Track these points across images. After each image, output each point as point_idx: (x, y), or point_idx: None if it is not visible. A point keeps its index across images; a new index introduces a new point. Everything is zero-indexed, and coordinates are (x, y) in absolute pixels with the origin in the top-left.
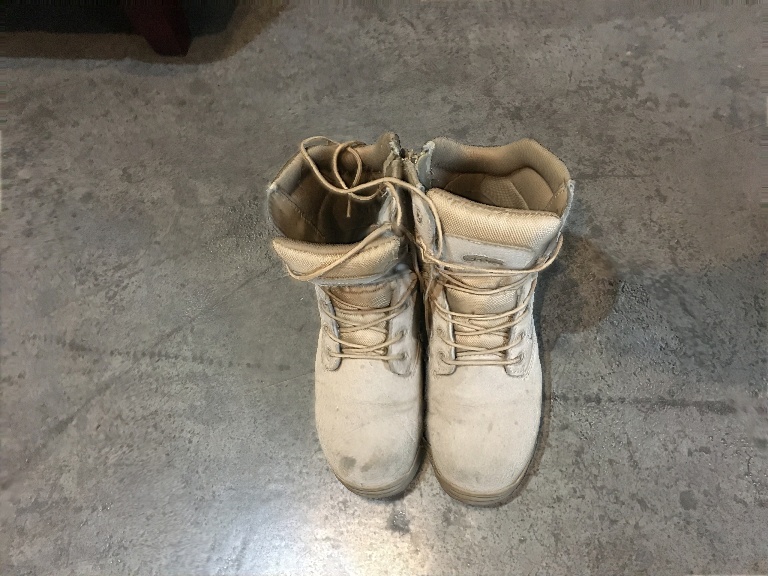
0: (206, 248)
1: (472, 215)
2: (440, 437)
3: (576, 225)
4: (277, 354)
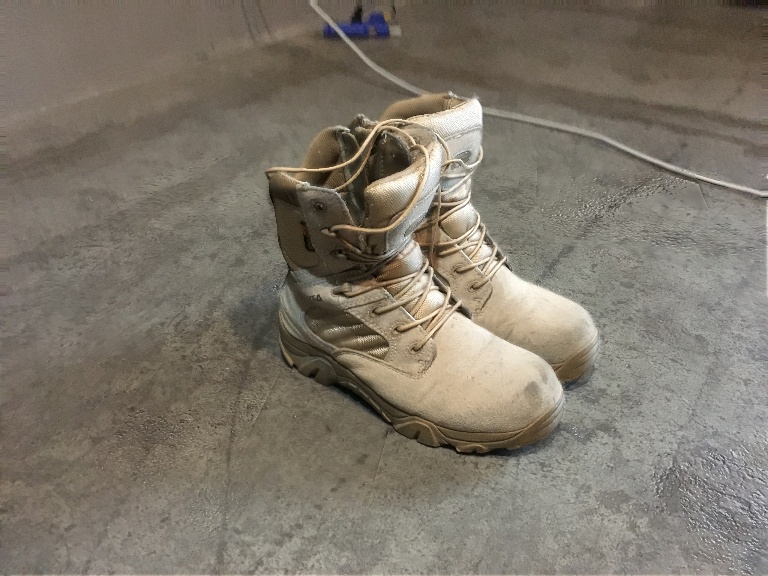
0: (141, 477)
1: (446, 115)
2: (537, 332)
3: None
4: (342, 459)
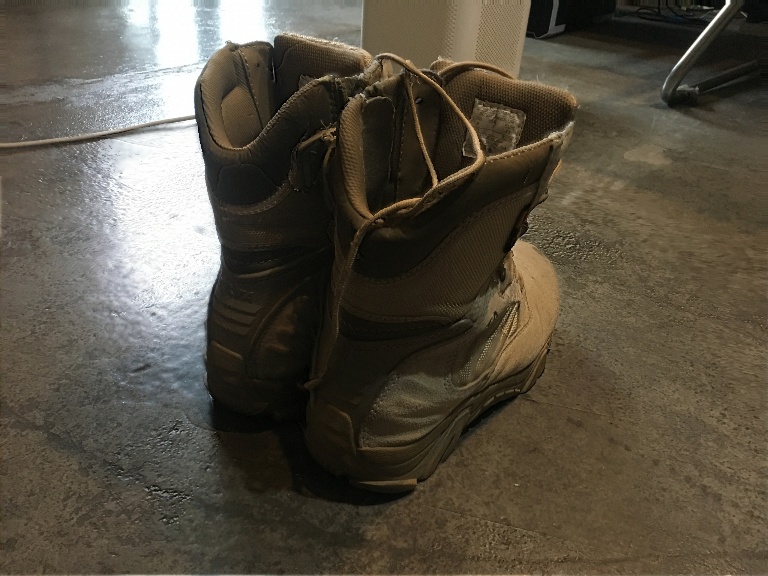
0: None
1: None
2: None
3: (101, 371)
4: (581, 440)
